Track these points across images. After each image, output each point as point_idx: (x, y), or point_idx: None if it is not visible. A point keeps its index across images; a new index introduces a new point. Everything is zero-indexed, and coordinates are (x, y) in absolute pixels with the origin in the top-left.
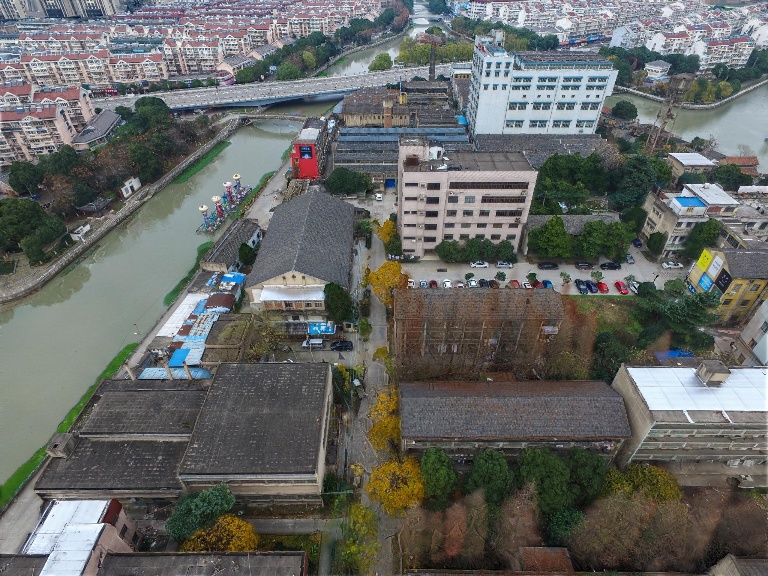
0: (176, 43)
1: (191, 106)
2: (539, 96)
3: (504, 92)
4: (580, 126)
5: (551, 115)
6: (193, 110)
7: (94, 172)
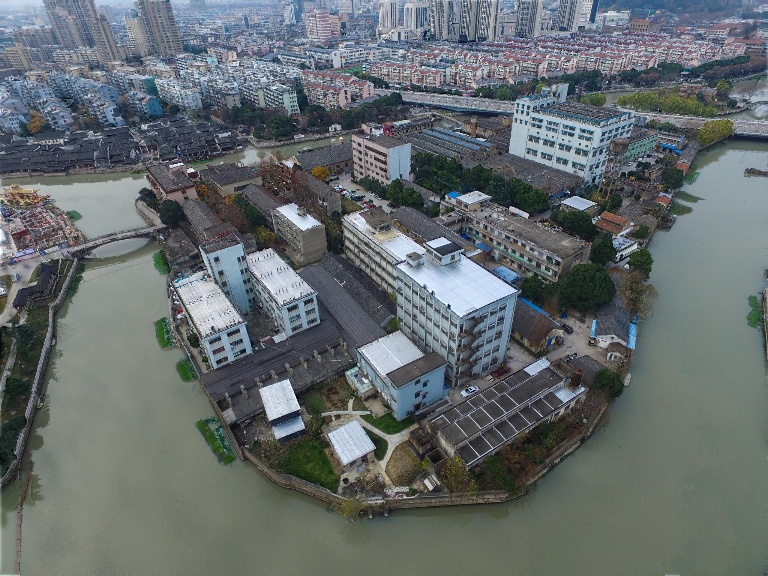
0: (459, 65)
1: (421, 103)
2: (548, 135)
3: (526, 127)
4: (575, 167)
5: (555, 152)
6: (424, 105)
7: (322, 116)
